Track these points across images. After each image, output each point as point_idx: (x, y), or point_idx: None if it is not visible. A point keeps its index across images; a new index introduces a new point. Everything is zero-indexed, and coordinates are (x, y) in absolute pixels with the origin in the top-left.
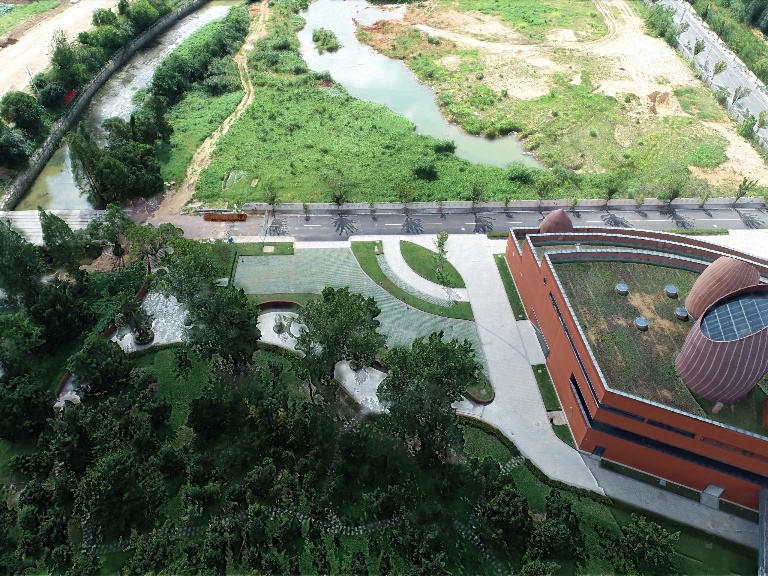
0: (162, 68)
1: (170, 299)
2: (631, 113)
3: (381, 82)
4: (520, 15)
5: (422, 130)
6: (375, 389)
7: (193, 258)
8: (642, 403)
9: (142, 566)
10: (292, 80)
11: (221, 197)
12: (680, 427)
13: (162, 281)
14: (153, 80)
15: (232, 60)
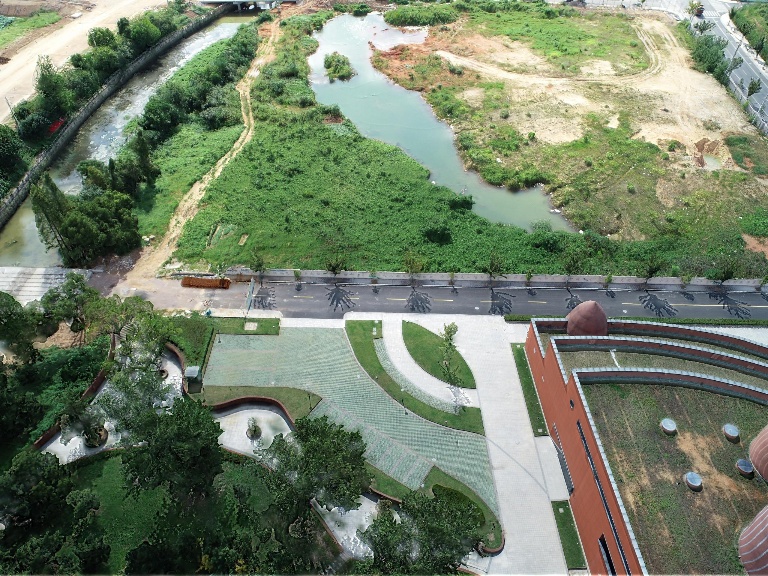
0: (156, 98)
1: None
2: (675, 165)
3: (395, 117)
4: (552, 43)
5: (437, 178)
6: (360, 524)
7: (159, 343)
8: None
9: None
10: (297, 114)
11: (204, 257)
12: None
13: (120, 372)
14: (144, 112)
15: (234, 88)
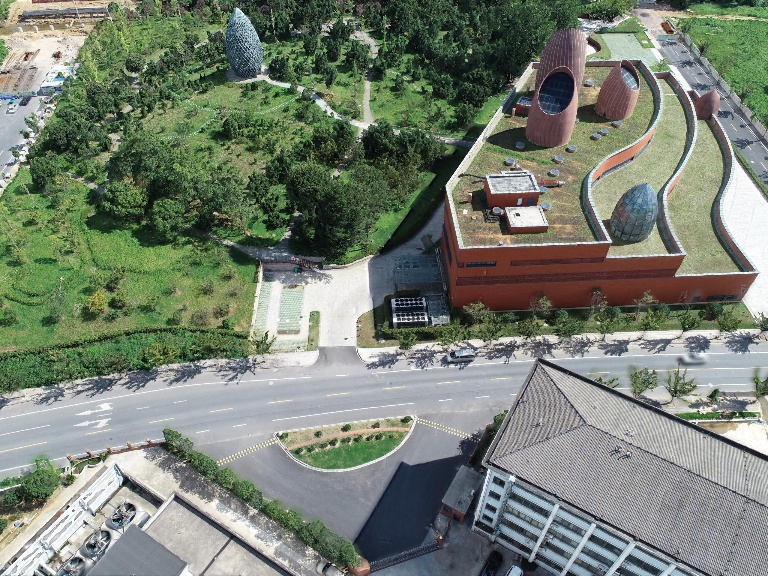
0: None
1: (592, 25)
2: None
3: None
4: None
5: None
6: None
7: (612, 8)
8: None
9: (444, 5)
10: None
11: None
12: None
13: None
14: None
15: None
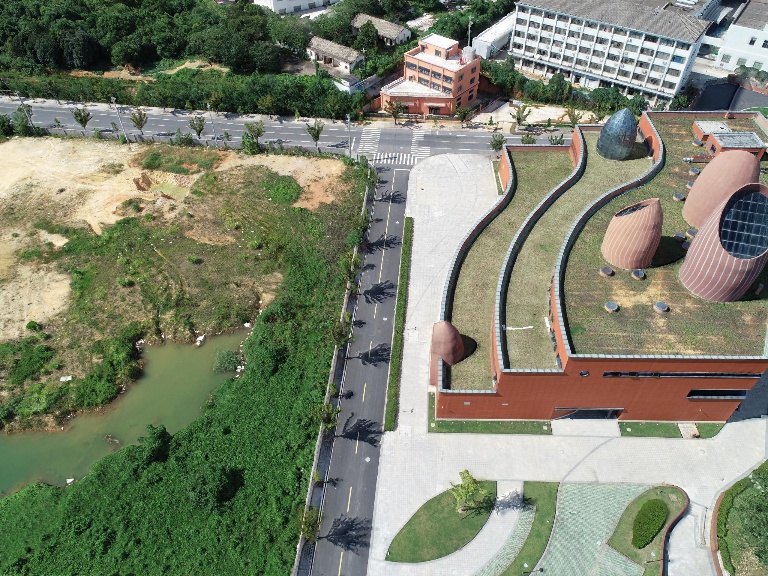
0: None
1: None
2: (168, 215)
3: None
4: None
5: (58, 474)
6: None
7: None
8: None
9: None
10: None
11: None
12: None
13: None
14: None
15: None
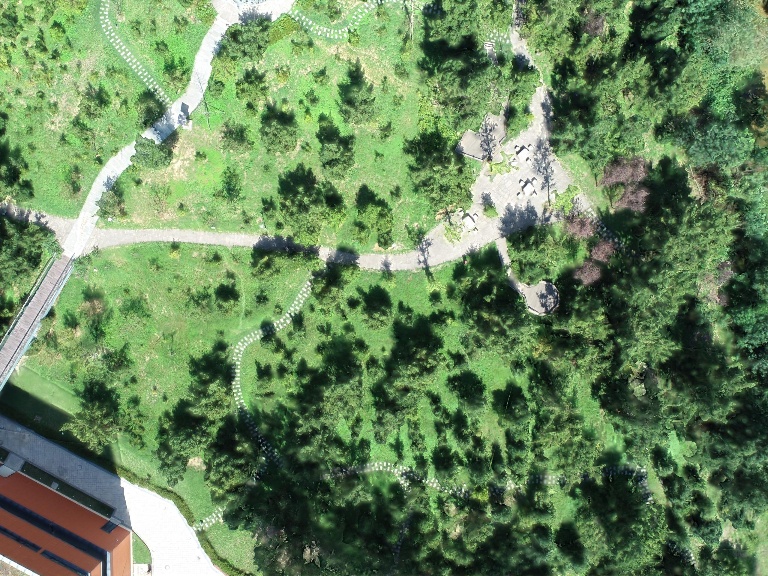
0: None
1: None
2: None
3: None
4: None
5: None
6: None
7: None
8: (35, 571)
9: (585, 447)
10: None
11: None
12: (5, 538)
13: None
14: None
15: None
